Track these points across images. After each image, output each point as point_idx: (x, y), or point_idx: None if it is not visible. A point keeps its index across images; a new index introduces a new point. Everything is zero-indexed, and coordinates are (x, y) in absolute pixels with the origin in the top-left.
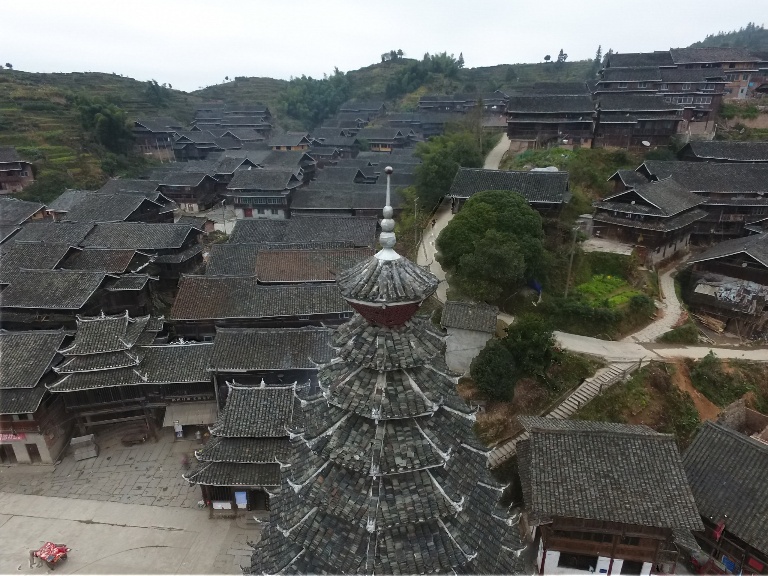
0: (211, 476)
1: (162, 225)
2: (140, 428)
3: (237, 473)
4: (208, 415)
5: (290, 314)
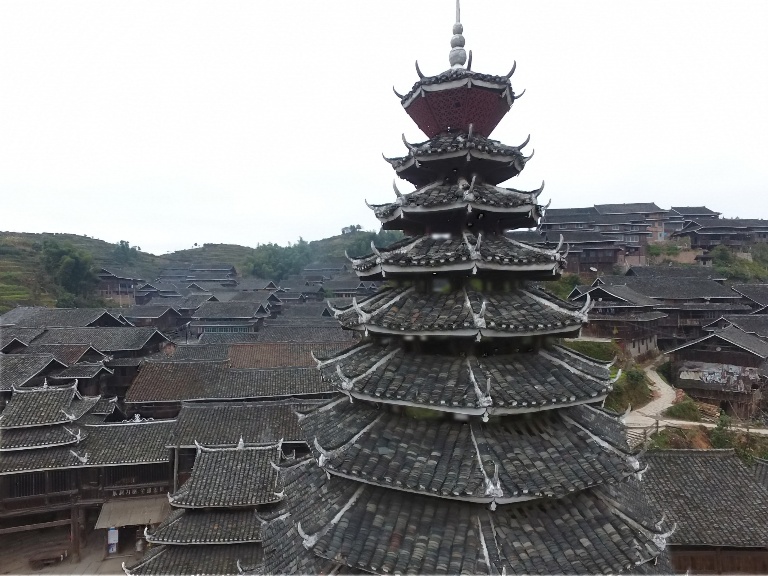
0: (162, 567)
1: (123, 329)
2: (58, 546)
3: (199, 562)
4: (158, 512)
5: (267, 395)
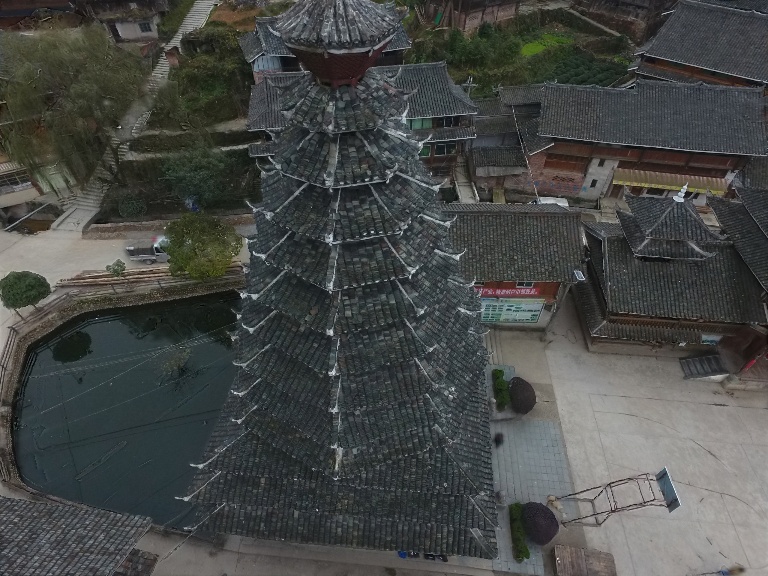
0: None
1: None
2: None
3: None
4: None
5: None
